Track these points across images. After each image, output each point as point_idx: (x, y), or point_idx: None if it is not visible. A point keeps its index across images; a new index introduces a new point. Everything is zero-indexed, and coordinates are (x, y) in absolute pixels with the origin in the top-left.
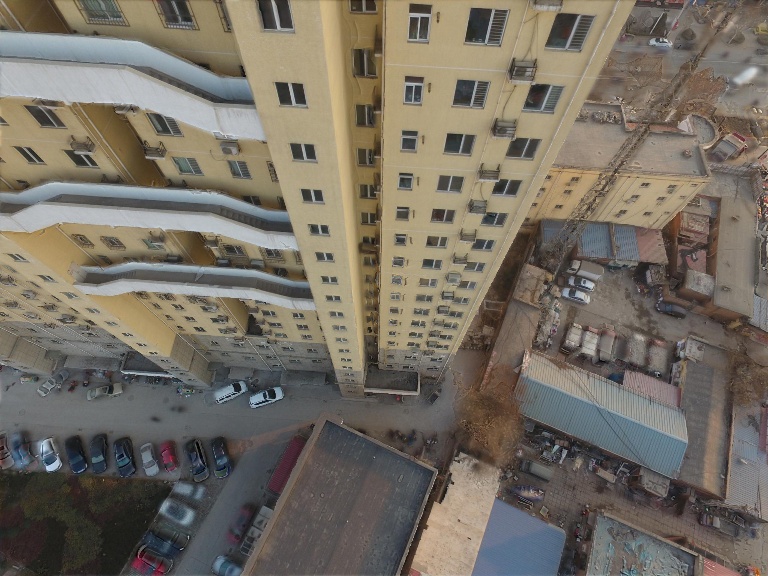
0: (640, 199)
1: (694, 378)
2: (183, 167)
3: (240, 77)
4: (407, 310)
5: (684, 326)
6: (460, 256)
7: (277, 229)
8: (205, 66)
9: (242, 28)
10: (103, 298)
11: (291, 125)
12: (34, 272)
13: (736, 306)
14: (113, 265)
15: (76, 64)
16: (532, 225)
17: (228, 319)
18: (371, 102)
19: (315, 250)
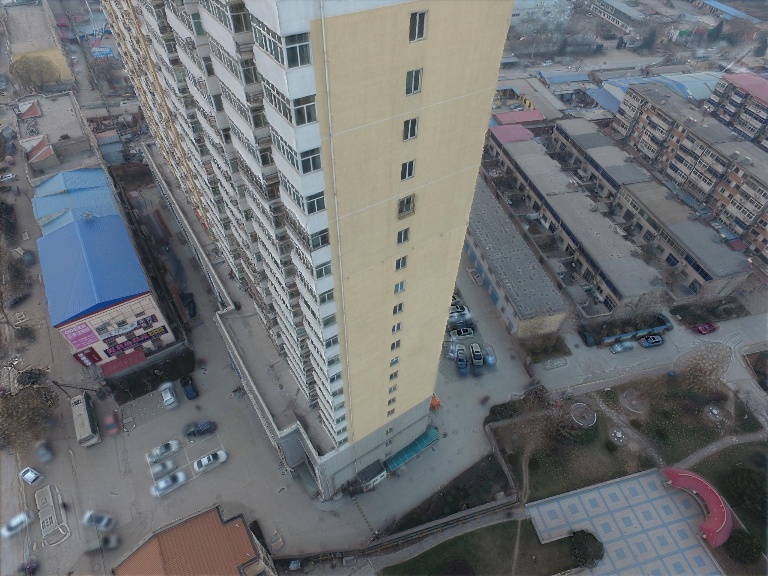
0: None
1: None
2: None
3: None
4: None
5: None
6: None
7: None
8: None
9: None
10: None
11: None
12: None
13: (135, 108)
14: None
15: None
16: (111, 172)
17: None
18: None
19: None
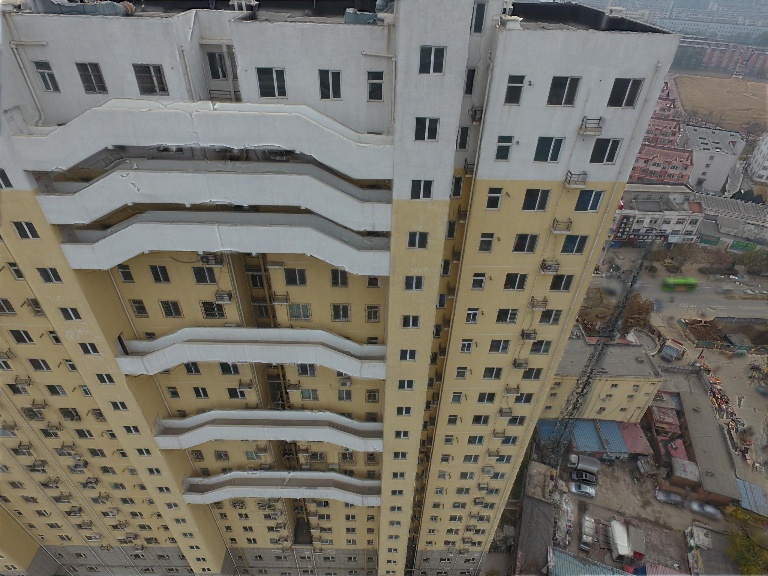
0: (614, 397)
1: (711, 567)
2: (304, 395)
3: (371, 345)
4: (448, 504)
5: (686, 514)
6: (493, 451)
7: (369, 436)
8: (347, 338)
9: (393, 328)
10: (194, 508)
11: (403, 370)
12: (158, 484)
13: (724, 490)
14: (214, 476)
15: (292, 345)
16: None
17: (285, 526)
18: (438, 351)
19: (394, 451)
